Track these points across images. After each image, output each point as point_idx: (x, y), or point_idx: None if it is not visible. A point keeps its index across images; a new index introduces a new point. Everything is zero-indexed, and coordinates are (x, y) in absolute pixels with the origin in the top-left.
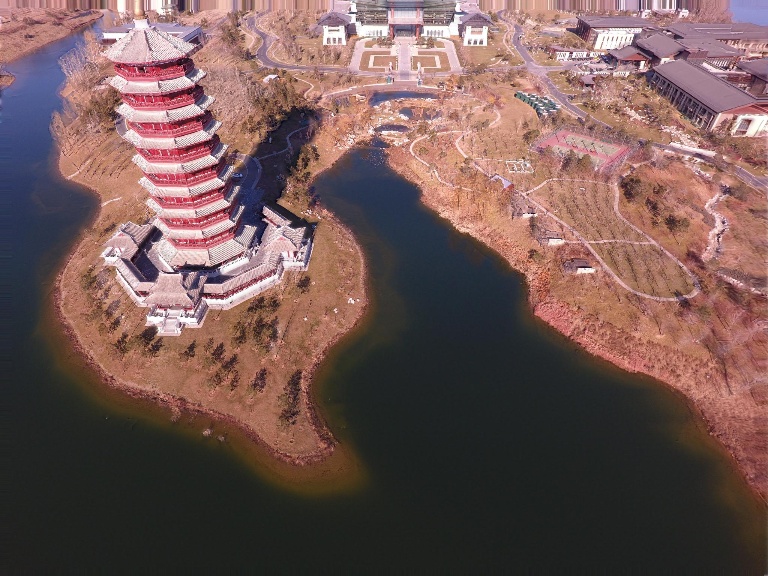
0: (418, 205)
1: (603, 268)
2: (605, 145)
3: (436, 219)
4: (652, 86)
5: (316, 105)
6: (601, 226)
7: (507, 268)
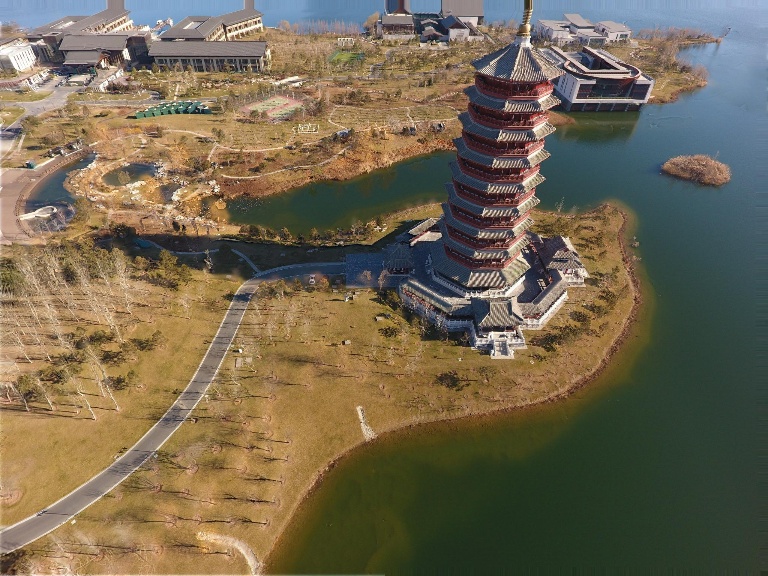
0: (347, 183)
1: (438, 121)
2: (272, 100)
3: (368, 177)
4: (162, 69)
5: (114, 221)
6: (393, 116)
7: (429, 155)
